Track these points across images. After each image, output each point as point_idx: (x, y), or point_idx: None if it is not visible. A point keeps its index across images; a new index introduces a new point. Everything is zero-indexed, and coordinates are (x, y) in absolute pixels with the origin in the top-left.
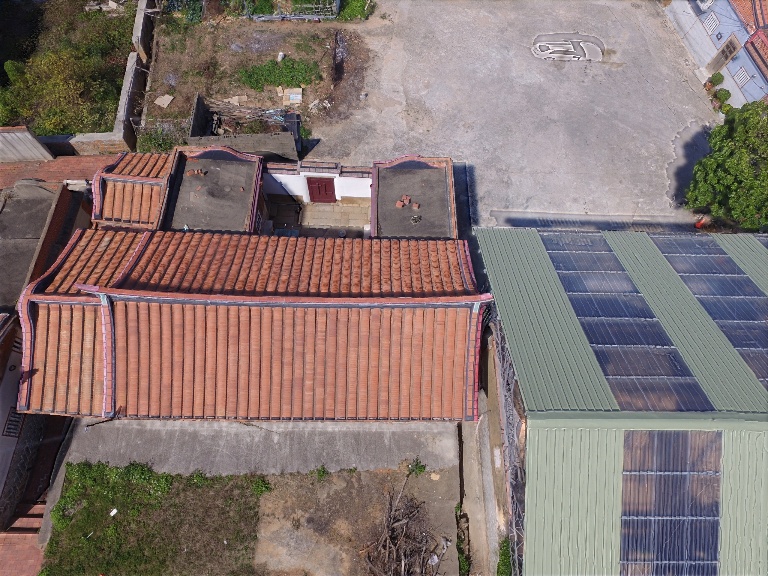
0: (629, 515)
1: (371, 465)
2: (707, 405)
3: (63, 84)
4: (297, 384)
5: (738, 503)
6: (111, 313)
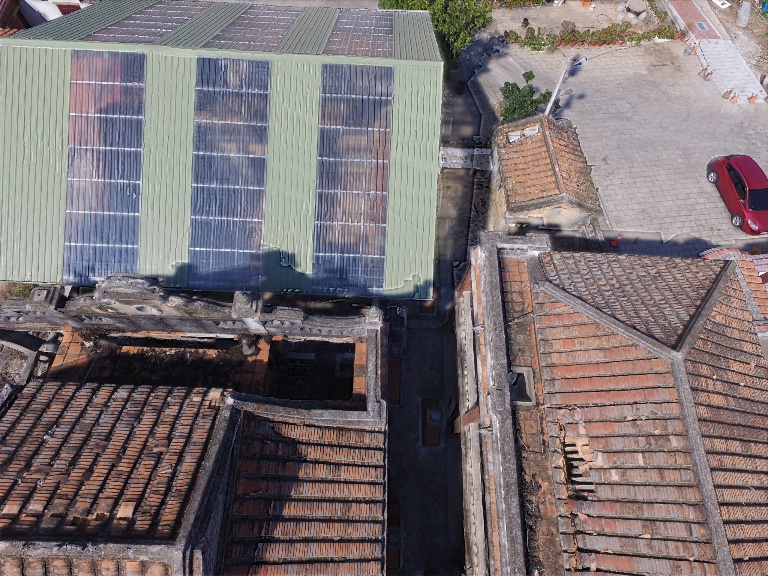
0: (75, 112)
1: None
2: None
3: None
4: None
5: (159, 109)
6: None
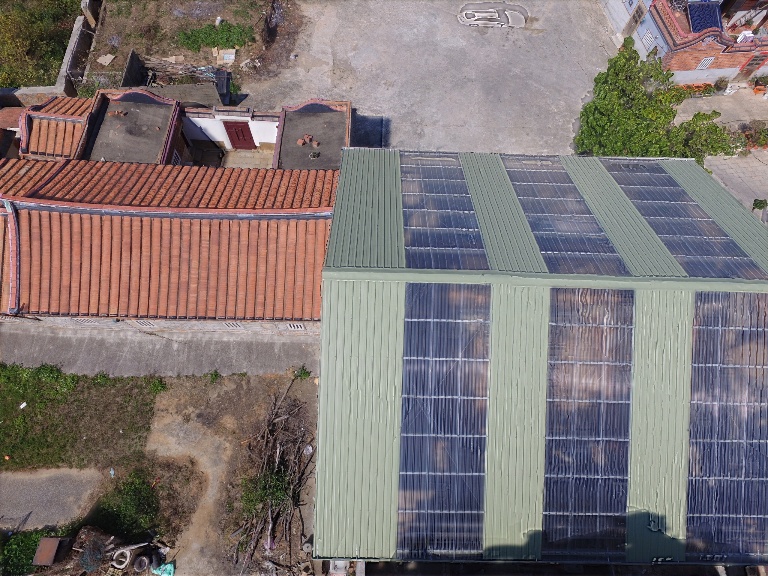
0: (410, 356)
1: (260, 371)
2: (484, 267)
3: (11, 42)
4: (183, 287)
5: (506, 348)
6: (16, 220)
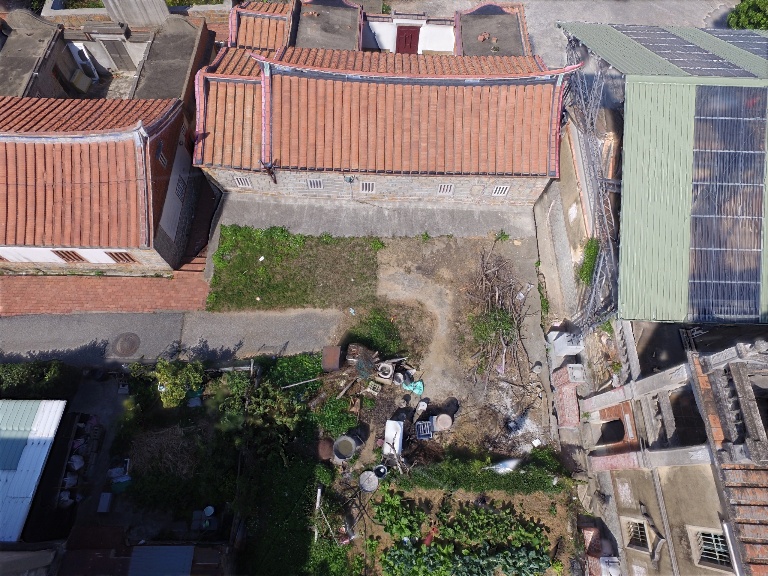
0: (699, 148)
1: (465, 233)
2: None
3: None
4: (414, 146)
5: None
6: (270, 84)
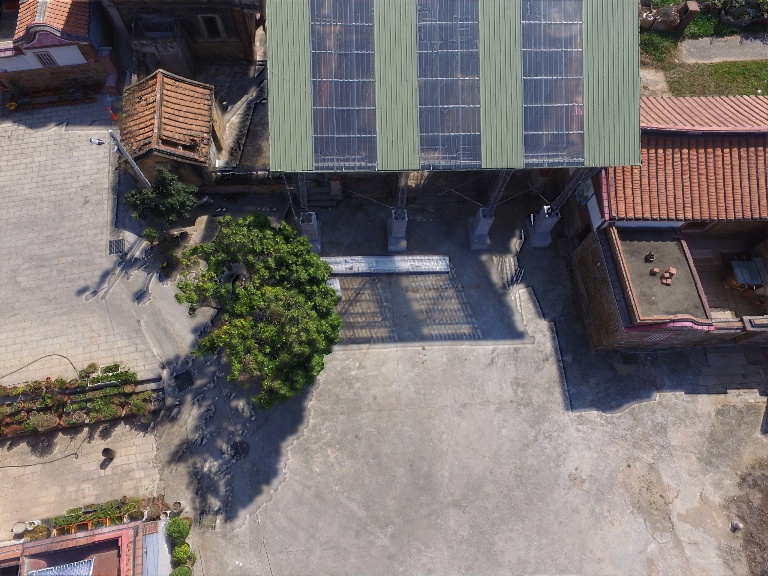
0: None
1: None
2: None
3: None
4: None
5: None
6: None
